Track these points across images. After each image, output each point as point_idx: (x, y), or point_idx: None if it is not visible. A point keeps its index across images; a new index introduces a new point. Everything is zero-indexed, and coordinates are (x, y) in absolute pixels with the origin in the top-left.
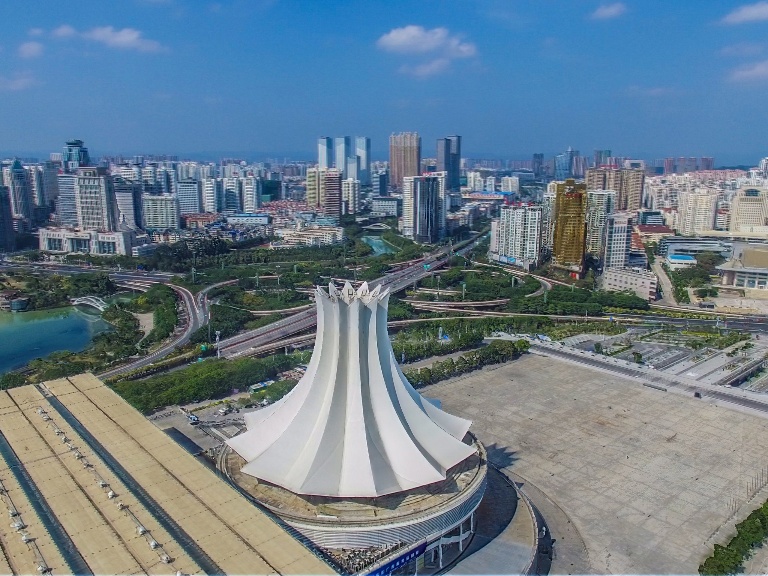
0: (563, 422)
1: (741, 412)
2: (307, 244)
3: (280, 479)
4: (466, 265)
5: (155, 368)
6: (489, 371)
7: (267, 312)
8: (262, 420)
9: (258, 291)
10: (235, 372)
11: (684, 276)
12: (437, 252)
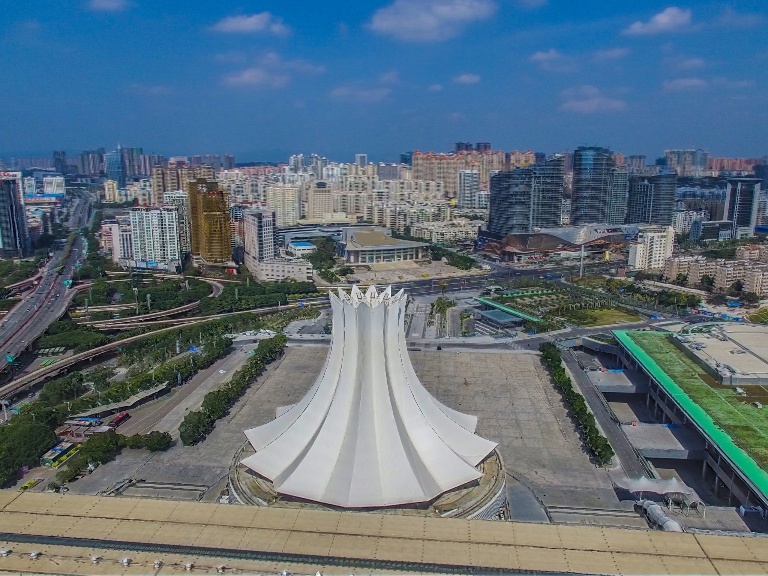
0: None
1: (478, 353)
2: None
3: (380, 500)
4: (102, 276)
5: None
6: (276, 370)
7: None
8: (274, 459)
9: None
10: (14, 446)
11: (315, 260)
12: (56, 266)
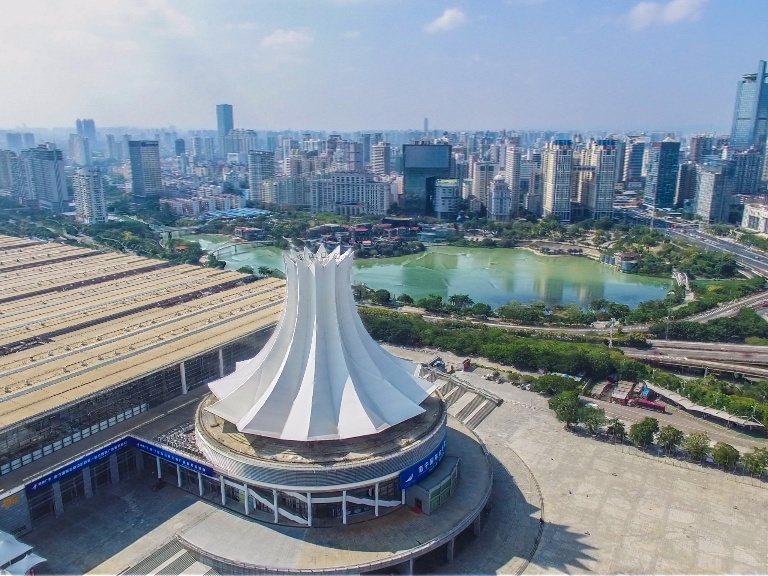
0: None
1: None
2: None
3: None
4: None
5: (571, 337)
6: None
7: None
8: None
9: None
10: (552, 354)
11: None
12: None
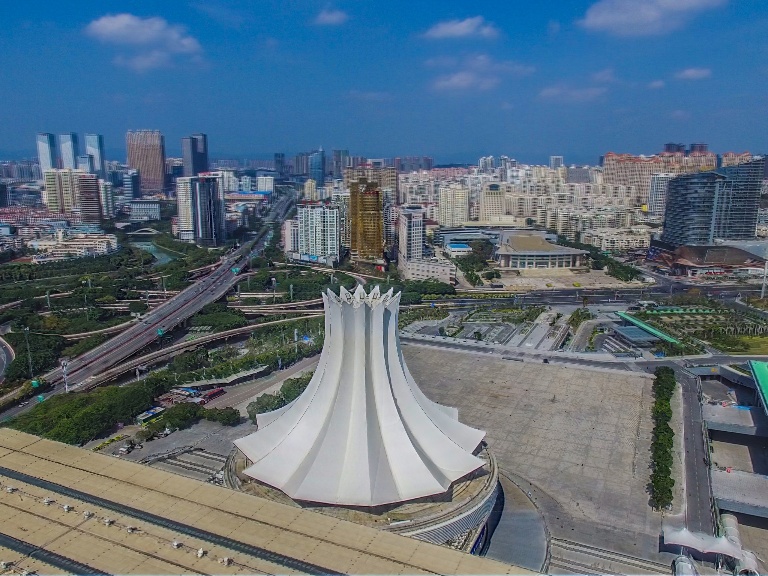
0: (465, 401)
1: (586, 370)
2: (78, 255)
3: (333, 497)
4: (269, 266)
5: None
6: None
7: (83, 335)
8: (262, 443)
9: (54, 312)
10: (115, 404)
11: (467, 262)
12: (235, 255)
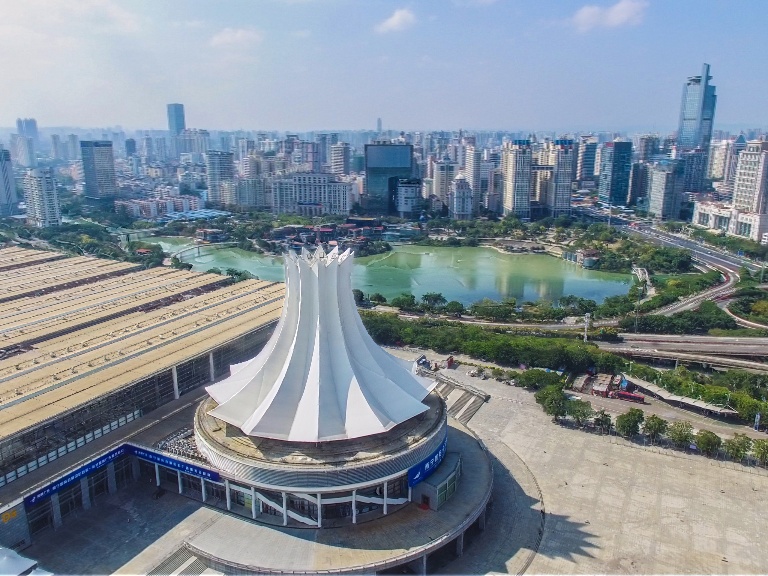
0: None
1: None
2: None
3: None
4: None
5: (545, 333)
6: None
7: (760, 326)
8: None
9: None
10: (533, 349)
11: None
12: None
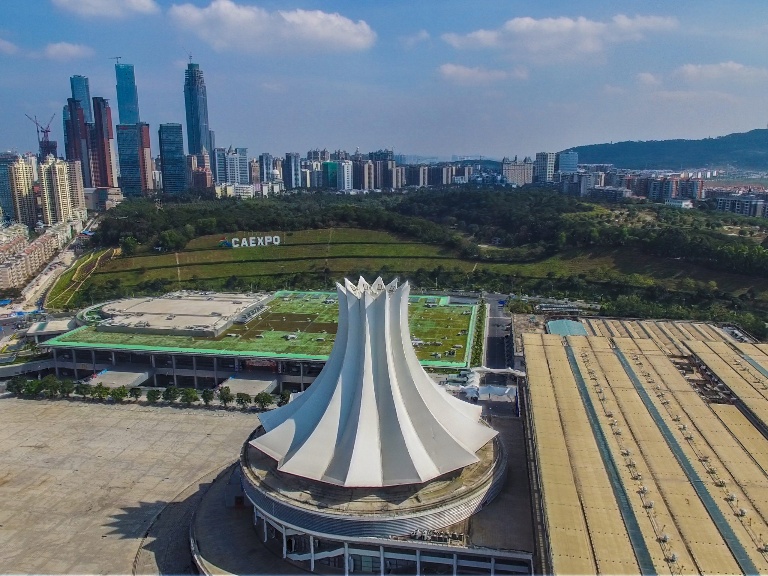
0: (8, 504)
1: None
2: None
3: None
4: None
5: None
6: None
7: None
8: None
9: None
10: None
11: None
12: None
